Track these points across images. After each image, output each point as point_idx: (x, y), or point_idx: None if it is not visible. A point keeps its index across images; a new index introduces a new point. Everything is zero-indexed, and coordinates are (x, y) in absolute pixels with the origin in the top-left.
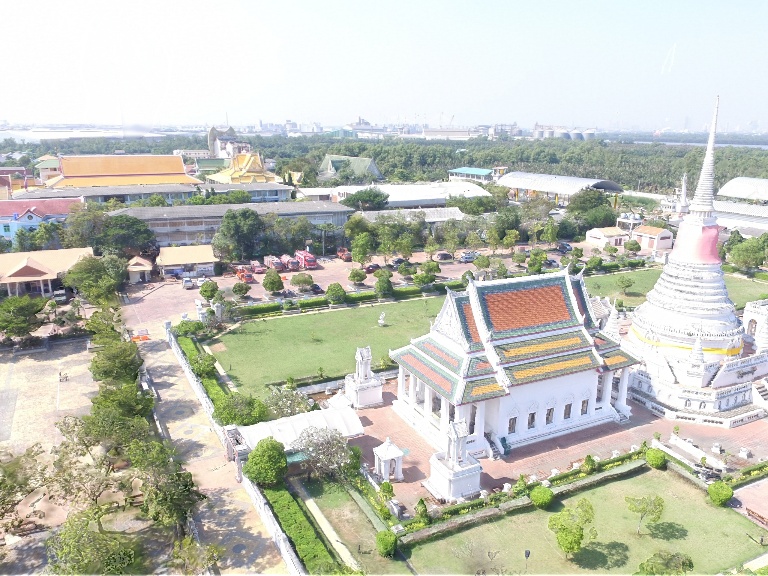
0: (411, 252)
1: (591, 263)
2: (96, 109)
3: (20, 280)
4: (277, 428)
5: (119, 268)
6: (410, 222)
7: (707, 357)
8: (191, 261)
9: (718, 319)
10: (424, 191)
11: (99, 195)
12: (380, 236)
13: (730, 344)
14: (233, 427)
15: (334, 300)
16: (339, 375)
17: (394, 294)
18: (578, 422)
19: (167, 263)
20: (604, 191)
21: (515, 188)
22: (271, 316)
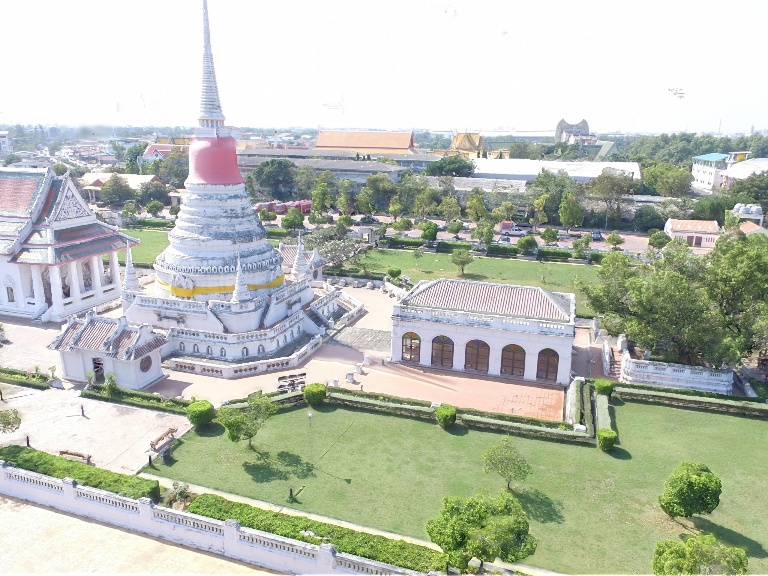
0: (373, 210)
1: None
2: (321, 89)
3: (93, 188)
4: None
5: (149, 190)
6: (426, 186)
7: (159, 291)
8: None
9: (183, 250)
10: None
11: (285, 155)
12: (341, 189)
13: (173, 280)
14: None
15: None
16: None
17: None
18: (4, 306)
19: None
20: None
21: (732, 177)
22: (154, 229)
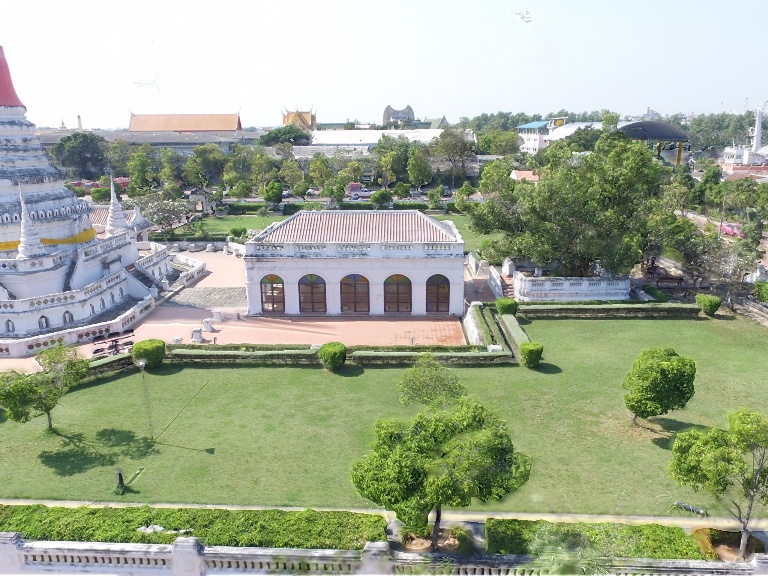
0: (204, 180)
1: (371, 198)
2: (130, 65)
3: None
4: None
5: None
6: None
7: None
8: None
9: None
10: None
11: None
12: (164, 159)
13: None
14: None
15: None
16: None
17: None
18: None
19: None
20: (669, 140)
21: None
22: None
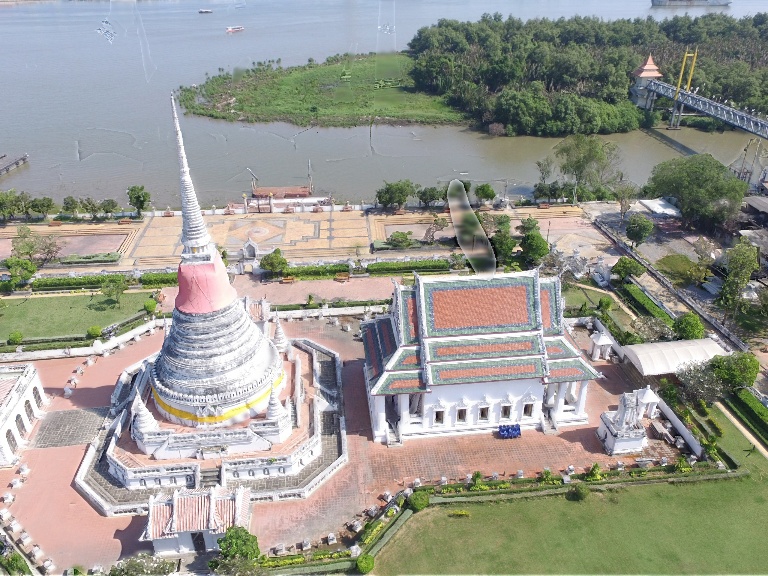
0: None
1: None
2: None
3: None
4: (693, 344)
5: None
6: None
7: None
8: None
9: None
10: None
11: None
12: None
13: None
14: (731, 352)
15: None
16: (656, 468)
17: None
18: None
19: None
20: None
21: None
22: None
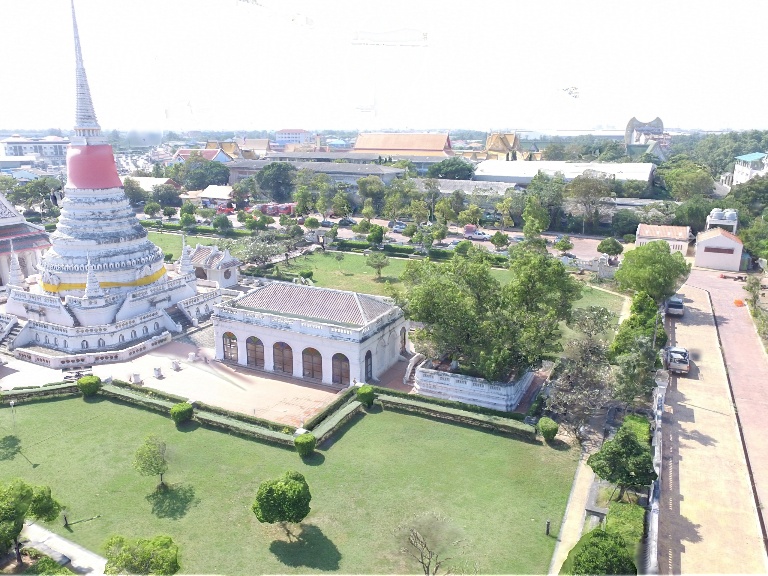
0: (349, 212)
1: None
2: (354, 93)
3: None
4: None
5: (160, 192)
6: (410, 188)
7: None
8: (213, 196)
9: (56, 249)
10: (554, 168)
11: (314, 158)
12: None
13: None
14: None
15: (187, 228)
16: None
17: (229, 233)
18: None
19: (201, 195)
20: None
21: None
22: None
